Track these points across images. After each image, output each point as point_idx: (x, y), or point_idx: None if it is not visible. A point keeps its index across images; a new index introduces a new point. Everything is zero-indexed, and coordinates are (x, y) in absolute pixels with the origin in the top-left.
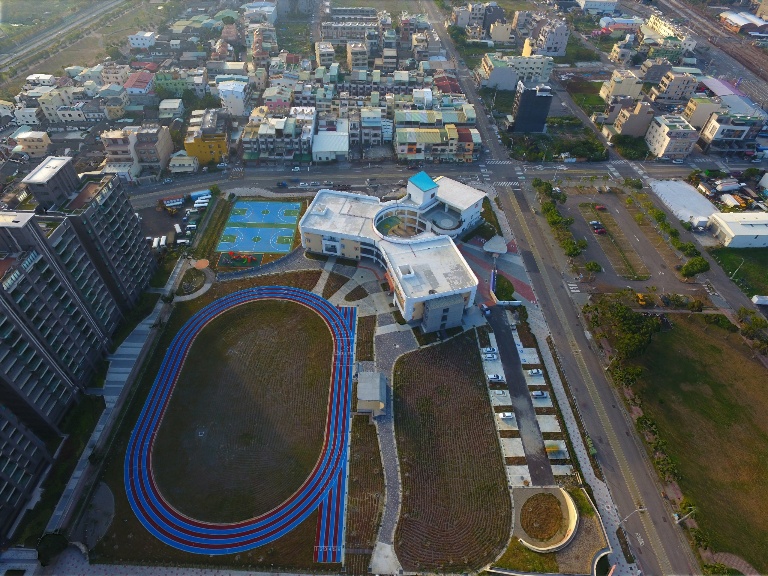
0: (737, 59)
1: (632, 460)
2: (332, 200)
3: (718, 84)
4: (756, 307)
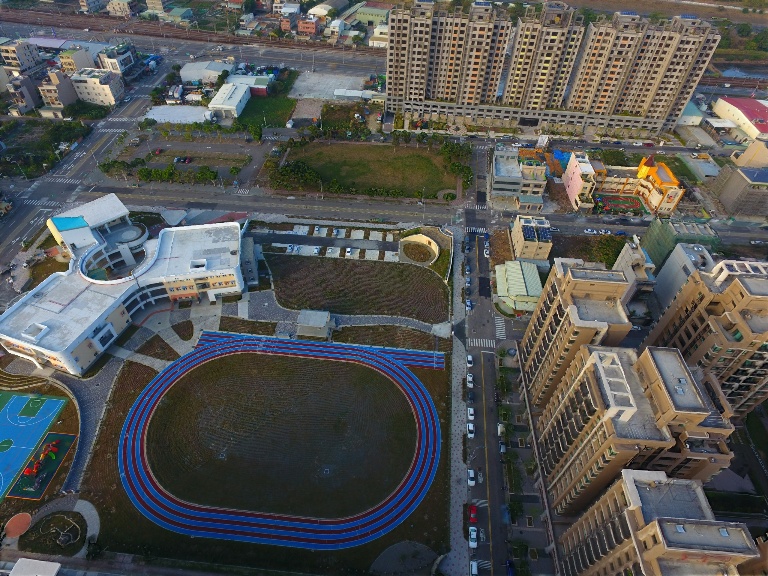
0: (2, 20)
1: (387, 208)
2: (20, 320)
3: (41, 40)
4: (293, 129)
